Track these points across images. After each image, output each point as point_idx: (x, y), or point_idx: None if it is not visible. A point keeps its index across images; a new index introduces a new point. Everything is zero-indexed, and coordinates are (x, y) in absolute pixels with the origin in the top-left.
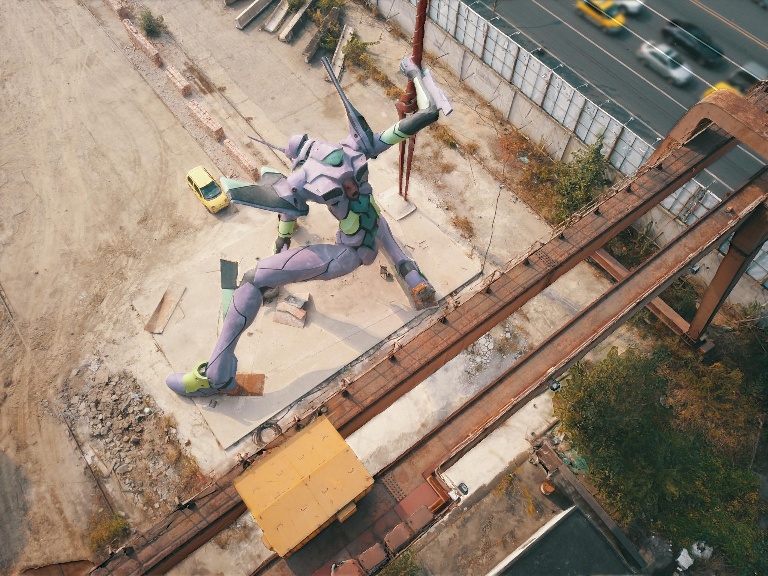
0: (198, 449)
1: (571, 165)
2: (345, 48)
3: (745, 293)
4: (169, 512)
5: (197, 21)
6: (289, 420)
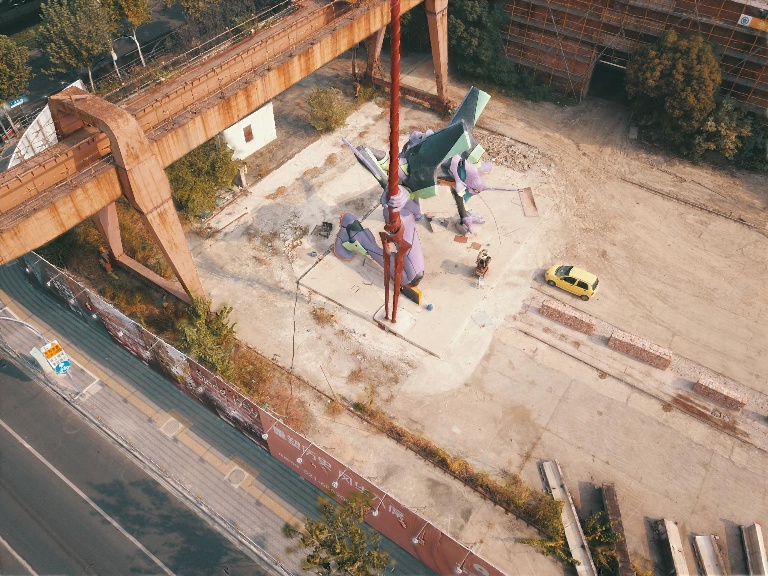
0: None
1: None
2: None
3: None
4: None
5: None
6: None
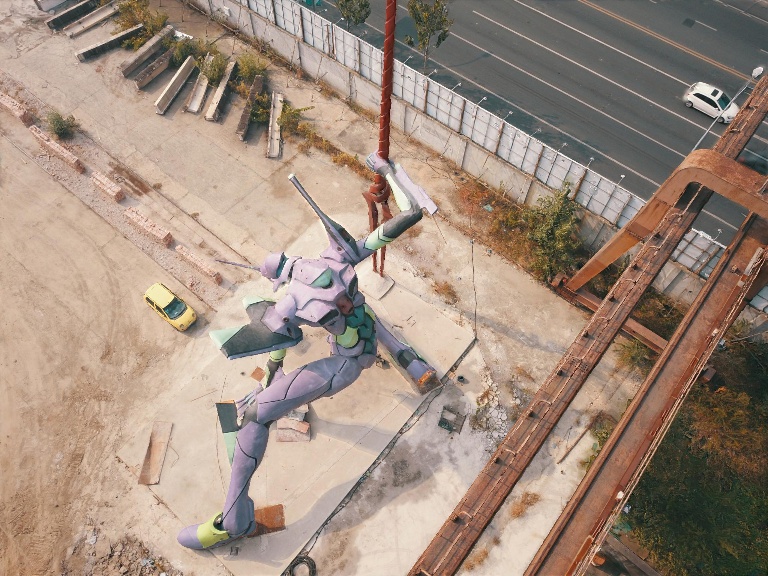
0: None
1: (539, 211)
2: (280, 120)
3: None
4: None
5: (111, 113)
6: (320, 549)
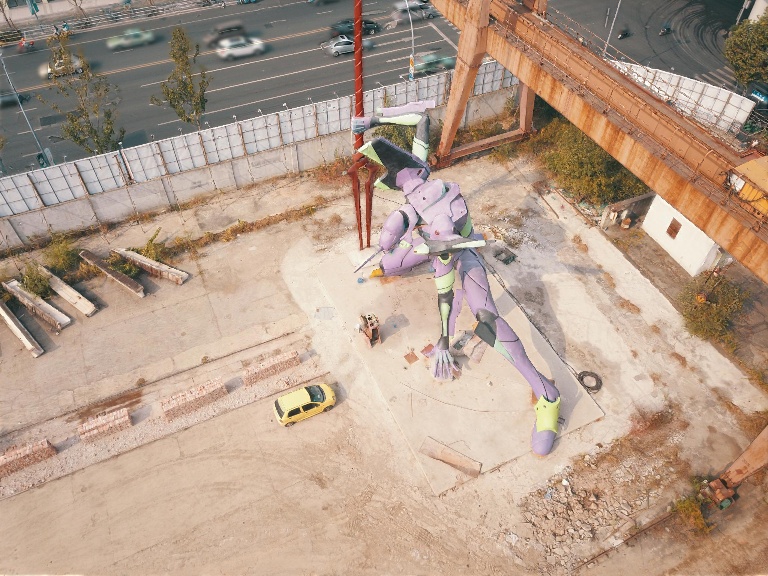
0: (604, 437)
1: None
2: (155, 253)
3: (501, 101)
4: (663, 466)
5: None
6: (575, 365)
